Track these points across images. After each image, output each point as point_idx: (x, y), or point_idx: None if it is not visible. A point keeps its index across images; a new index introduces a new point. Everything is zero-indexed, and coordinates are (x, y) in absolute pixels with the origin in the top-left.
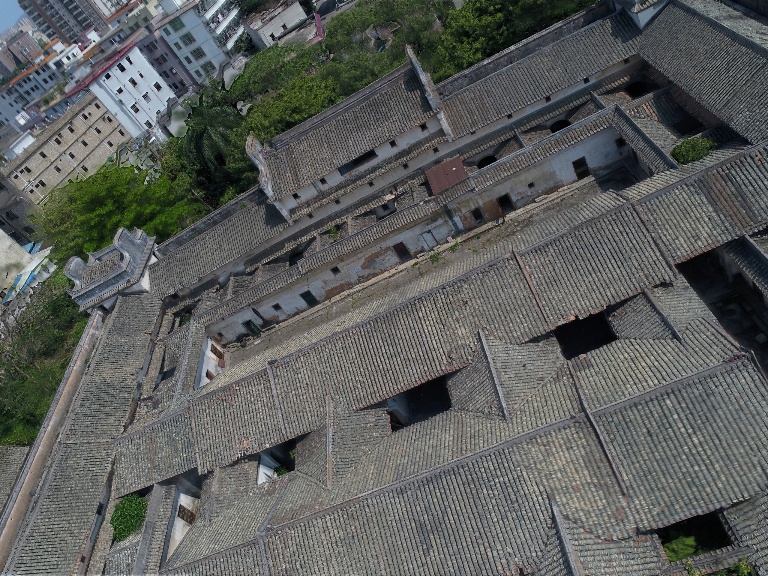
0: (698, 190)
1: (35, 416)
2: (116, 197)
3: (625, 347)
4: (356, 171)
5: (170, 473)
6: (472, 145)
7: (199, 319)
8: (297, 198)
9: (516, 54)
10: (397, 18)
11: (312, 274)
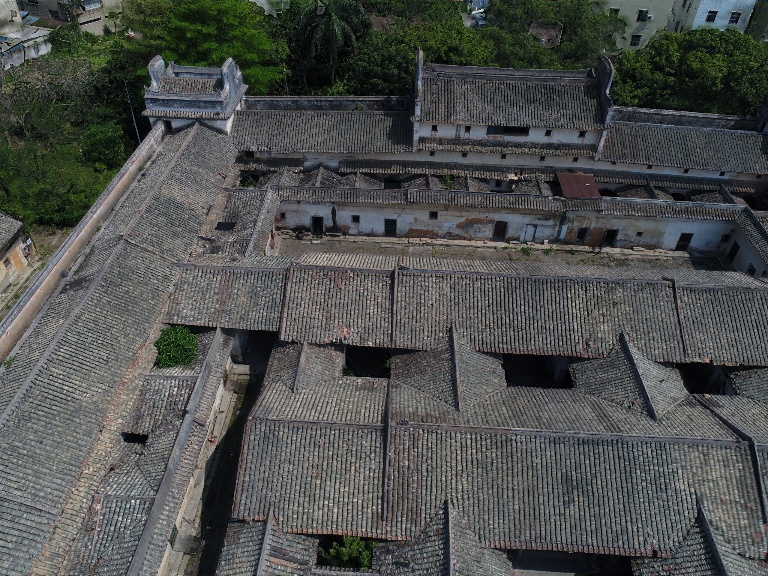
0: None
1: (9, 194)
2: (222, 24)
3: (752, 404)
4: (501, 137)
5: (241, 324)
6: (606, 173)
7: (277, 190)
8: (434, 130)
9: (669, 119)
10: (579, 27)
11: (411, 207)
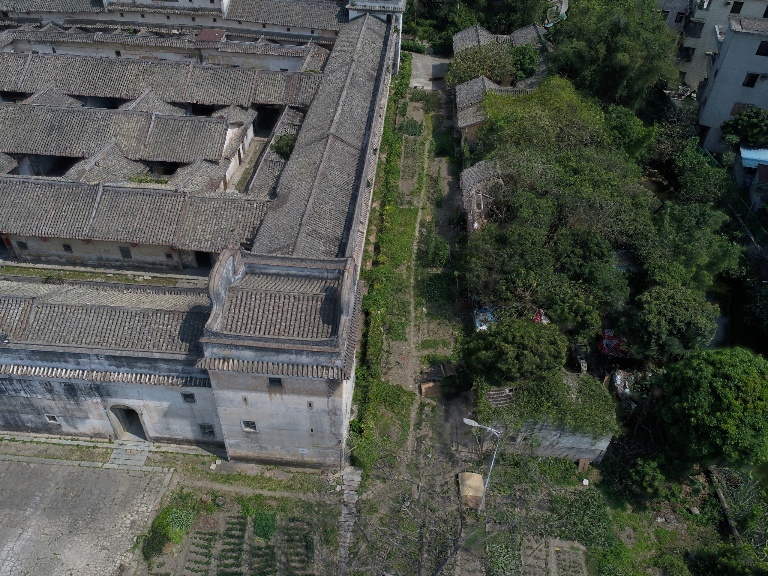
0: (285, 79)
1: None
2: None
3: None
4: (162, 3)
5: None
6: (237, 30)
7: (13, 33)
8: None
9: None
10: None
11: (102, 47)
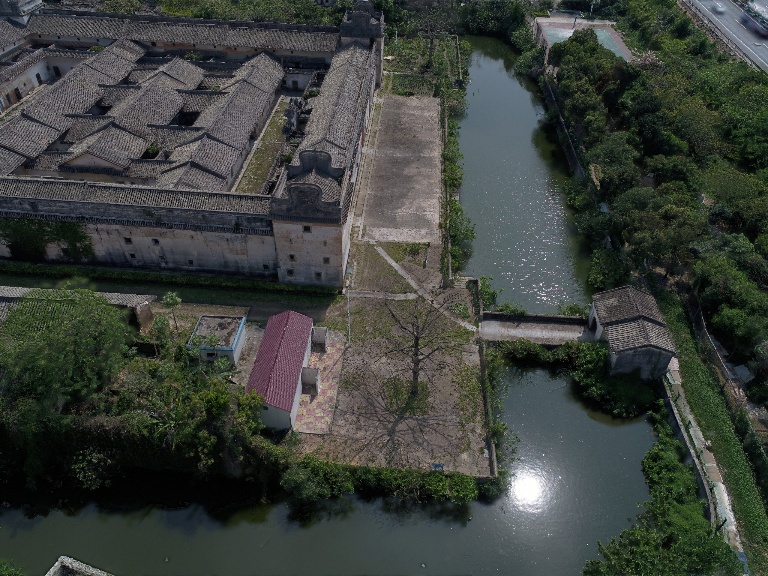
0: (119, 47)
1: None
2: None
3: None
4: None
5: (13, 167)
6: None
7: None
8: None
9: None
10: None
11: None
